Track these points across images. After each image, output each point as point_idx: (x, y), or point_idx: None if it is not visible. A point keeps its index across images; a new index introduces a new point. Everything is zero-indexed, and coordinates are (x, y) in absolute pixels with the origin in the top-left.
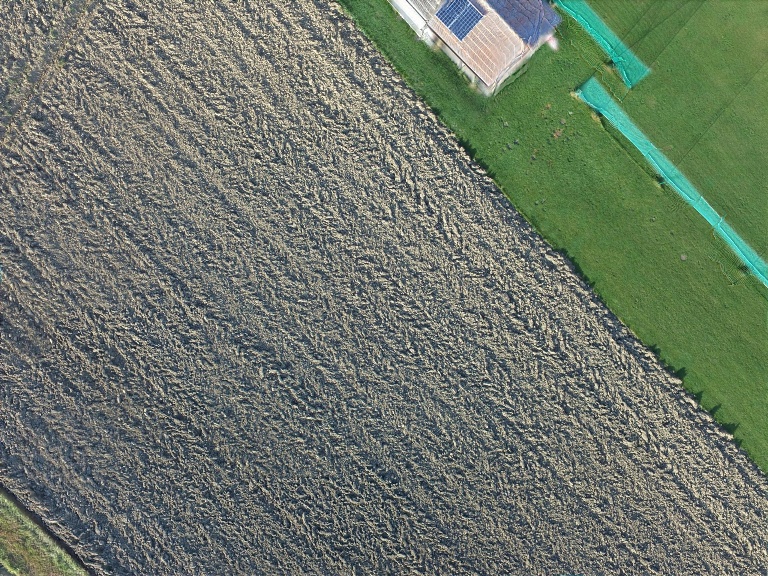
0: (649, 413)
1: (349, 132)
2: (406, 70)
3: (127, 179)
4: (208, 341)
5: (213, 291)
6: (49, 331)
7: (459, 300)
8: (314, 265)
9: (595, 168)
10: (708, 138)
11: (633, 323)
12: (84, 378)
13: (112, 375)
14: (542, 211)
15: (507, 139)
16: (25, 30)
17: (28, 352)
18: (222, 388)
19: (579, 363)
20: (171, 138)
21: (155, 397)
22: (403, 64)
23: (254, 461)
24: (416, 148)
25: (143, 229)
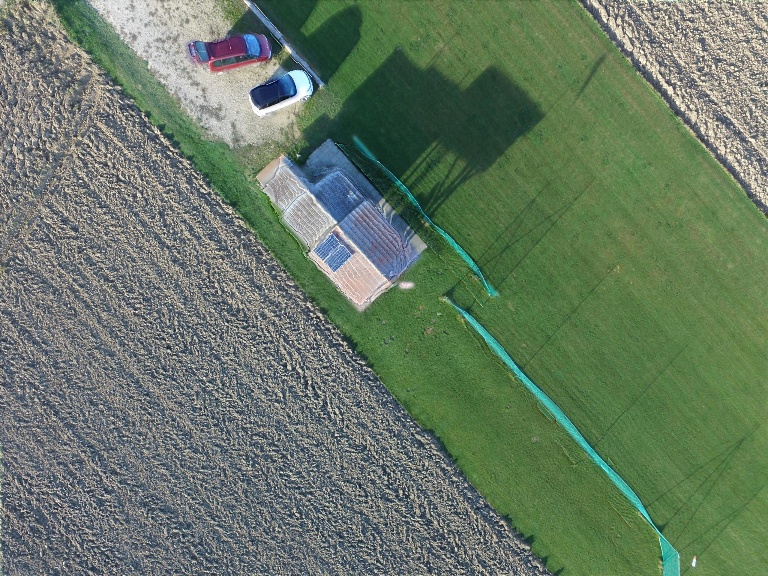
0: (501, 574)
1: (248, 328)
2: (299, 276)
3: (56, 365)
4: (121, 504)
5: (126, 461)
6: None
7: (339, 472)
8: (215, 440)
9: (459, 362)
10: (556, 339)
11: (489, 495)
12: (12, 535)
13: (36, 532)
14: (413, 397)
15: (384, 335)
16: None
17: None
18: (131, 544)
19: (442, 528)
20: (95, 331)
21: (73, 552)
22: (296, 271)
23: None
24: (305, 342)
25: (68, 408)
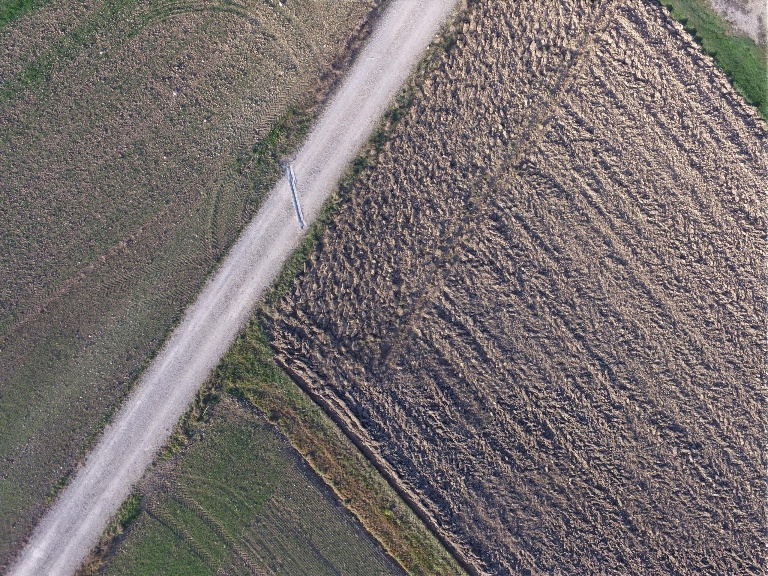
0: None
1: (767, 237)
2: None
3: (567, 274)
4: (628, 421)
5: (635, 376)
6: (490, 405)
7: None
8: (727, 356)
9: None
10: None
11: None
12: (518, 448)
13: (543, 447)
14: None
15: None
16: (489, 142)
17: (474, 423)
18: (638, 463)
19: None
20: (608, 239)
21: (579, 468)
22: None
23: (663, 531)
24: None
25: (578, 319)
